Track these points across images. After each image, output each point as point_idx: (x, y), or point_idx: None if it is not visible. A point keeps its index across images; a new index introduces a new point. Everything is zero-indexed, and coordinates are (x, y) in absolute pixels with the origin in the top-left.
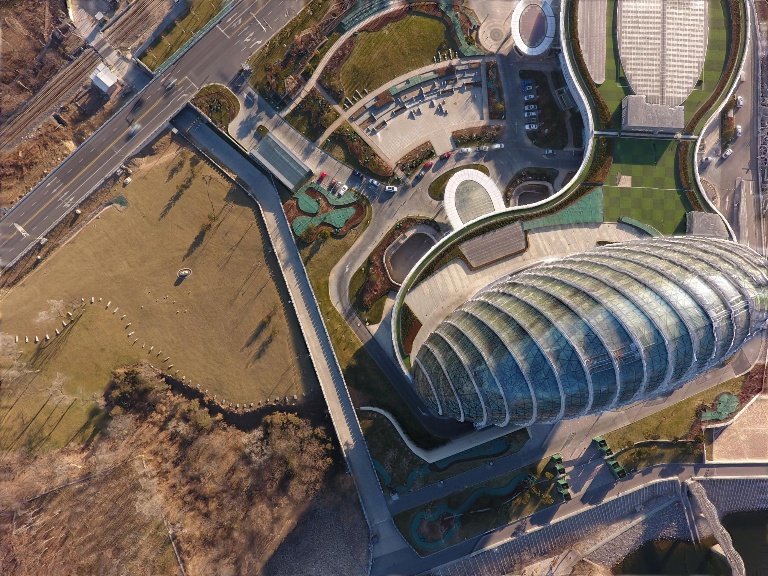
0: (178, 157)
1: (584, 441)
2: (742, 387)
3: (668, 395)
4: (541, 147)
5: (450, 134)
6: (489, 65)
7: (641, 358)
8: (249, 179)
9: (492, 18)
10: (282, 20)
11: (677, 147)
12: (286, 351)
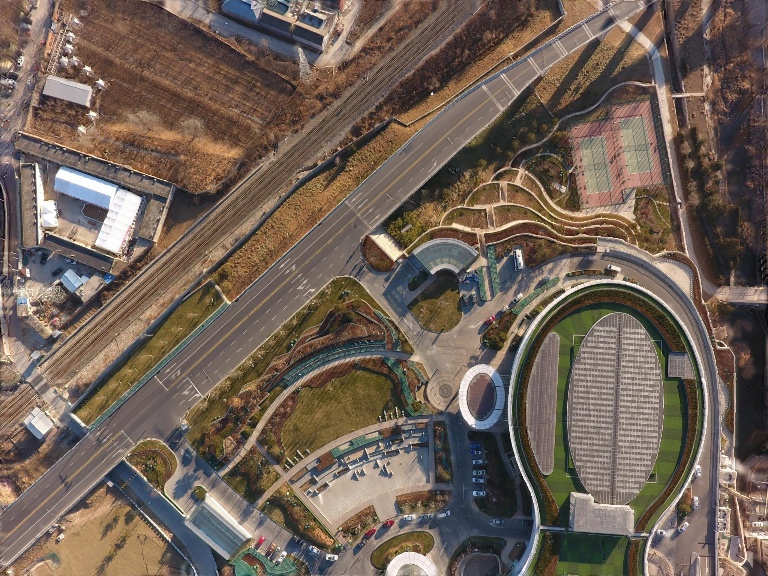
0: (113, 511)
1: None
2: None
3: None
4: (489, 514)
5: (394, 499)
6: None
7: None
8: (185, 539)
9: (441, 373)
10: (223, 372)
11: (627, 545)
12: None
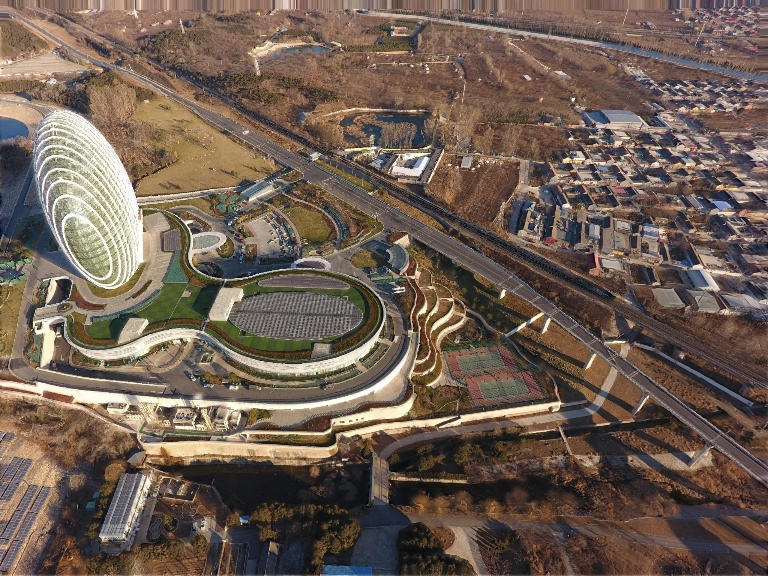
0: (272, 170)
1: None
2: None
3: (27, 315)
4: None
5: None
6: None
7: None
8: None
9: None
10: None
11: None
12: (159, 192)
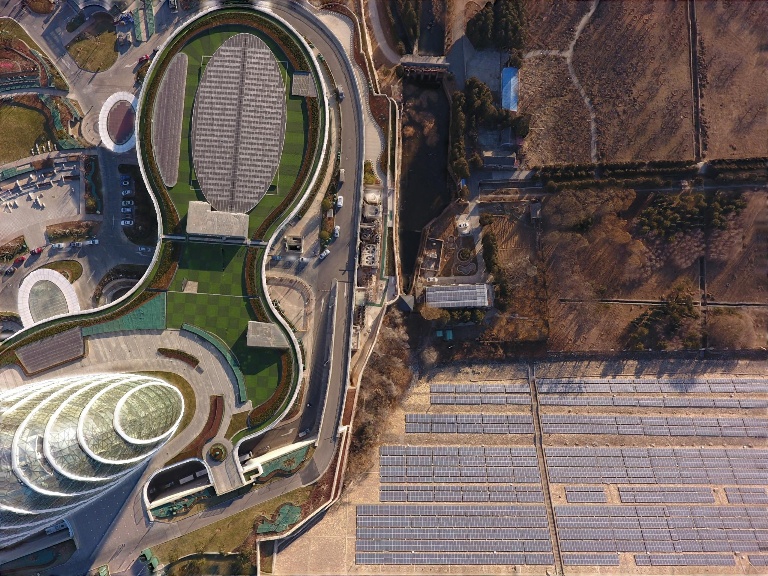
0: None
1: (133, 553)
2: (309, 497)
3: (226, 506)
4: (137, 244)
5: (44, 228)
6: (86, 159)
7: None
8: None
9: (96, 110)
10: None
11: (246, 253)
12: None
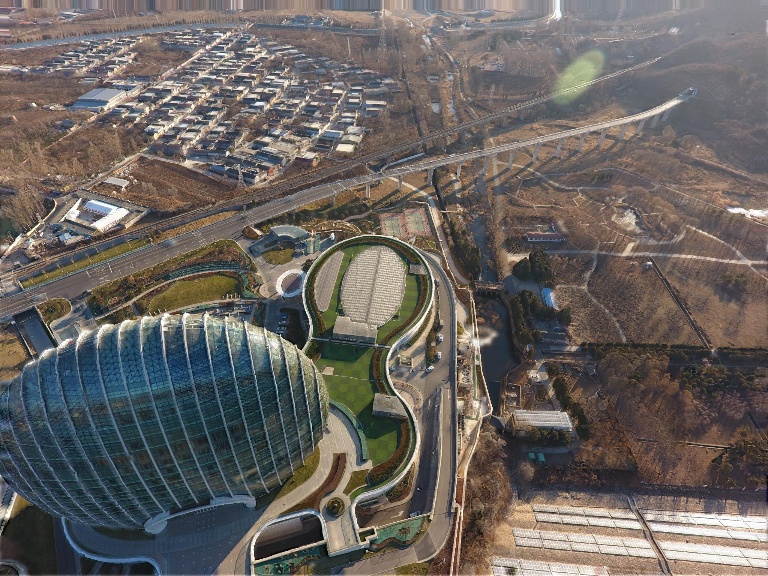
0: (2, 338)
1: None
2: (425, 575)
3: (335, 573)
4: None
5: None
6: (259, 303)
7: (97, 342)
8: None
9: (272, 281)
10: (131, 271)
11: (374, 352)
12: None
